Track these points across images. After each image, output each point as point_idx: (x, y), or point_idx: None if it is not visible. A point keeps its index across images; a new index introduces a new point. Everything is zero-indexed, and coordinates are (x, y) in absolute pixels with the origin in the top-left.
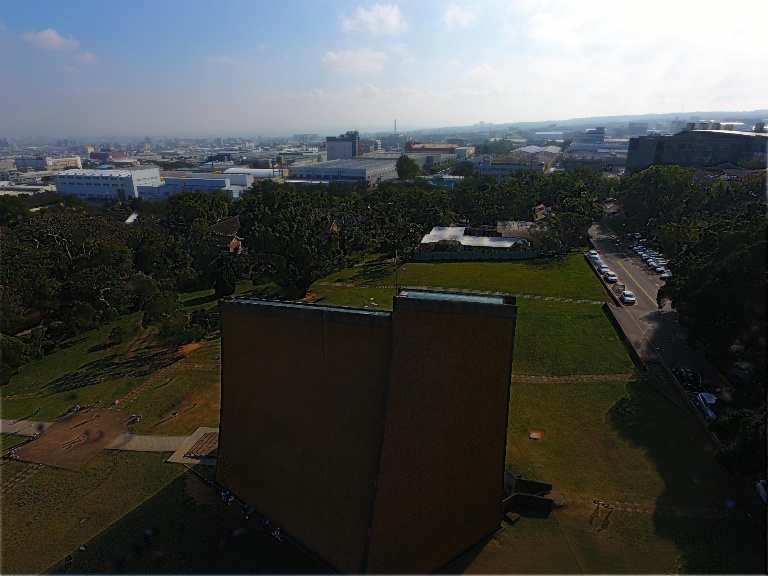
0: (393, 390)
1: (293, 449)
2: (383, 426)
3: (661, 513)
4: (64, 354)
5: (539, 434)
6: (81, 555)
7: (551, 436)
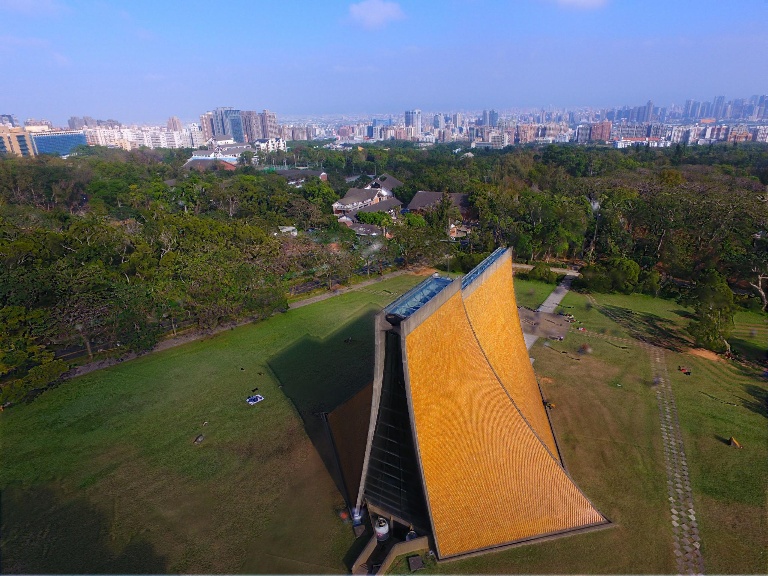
0: None
1: None
2: None
3: None
4: (665, 303)
5: None
6: None
7: None
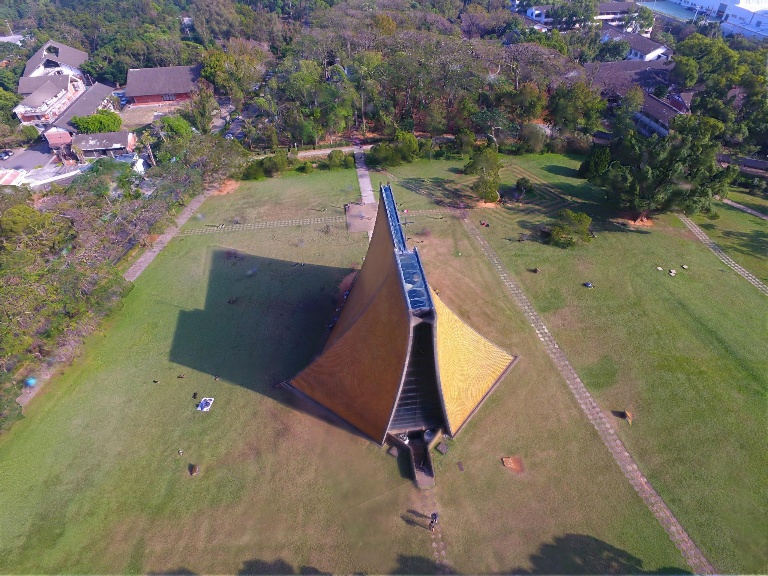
0: (371, 306)
1: (357, 296)
2: (356, 320)
3: (440, 575)
4: (439, 164)
5: (513, 466)
6: (300, 266)
7: (515, 477)
